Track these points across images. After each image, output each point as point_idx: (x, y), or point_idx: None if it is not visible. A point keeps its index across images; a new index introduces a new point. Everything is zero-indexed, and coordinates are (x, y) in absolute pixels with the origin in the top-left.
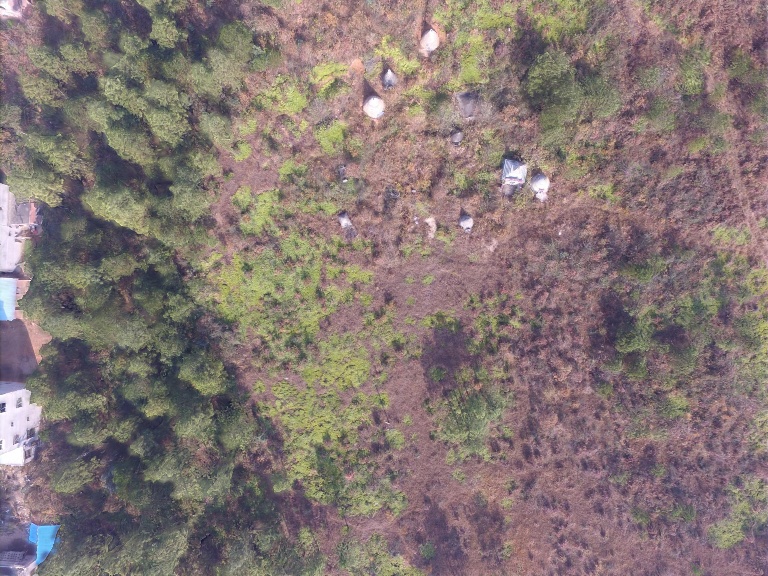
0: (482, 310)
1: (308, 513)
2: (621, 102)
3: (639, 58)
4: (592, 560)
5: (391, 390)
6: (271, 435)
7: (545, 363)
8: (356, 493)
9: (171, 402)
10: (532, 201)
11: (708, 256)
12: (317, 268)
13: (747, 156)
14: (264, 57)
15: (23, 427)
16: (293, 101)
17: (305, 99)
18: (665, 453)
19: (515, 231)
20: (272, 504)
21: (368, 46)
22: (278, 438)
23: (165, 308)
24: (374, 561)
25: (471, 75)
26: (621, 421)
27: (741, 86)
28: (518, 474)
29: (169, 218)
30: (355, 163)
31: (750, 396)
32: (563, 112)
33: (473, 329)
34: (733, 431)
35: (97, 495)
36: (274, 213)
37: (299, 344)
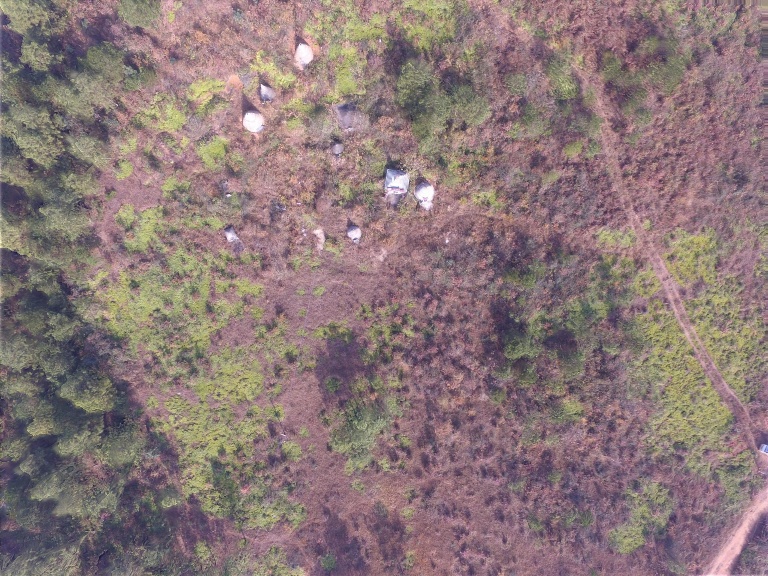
0: (375, 320)
1: (204, 527)
2: (494, 109)
3: (508, 65)
4: (495, 568)
5: (286, 402)
6: (165, 450)
7: (438, 371)
8: (253, 506)
9: (54, 421)
10: (415, 210)
11: (593, 260)
12: (206, 283)
13: (627, 159)
14: (136, 76)
15: None
16: (172, 118)
17: (184, 116)
18: (563, 458)
19: (403, 240)
20: (163, 519)
21: (242, 62)
22: (172, 453)
23: (48, 327)
24: (273, 574)
25: (348, 87)
26: (518, 427)
27: (617, 89)
28: (418, 483)
29: (46, 238)
30: (235, 178)
31: (644, 399)
32: (431, 121)
33: (366, 339)
34: (629, 435)
35: (0, 513)
36: (159, 230)
37: (190, 359)
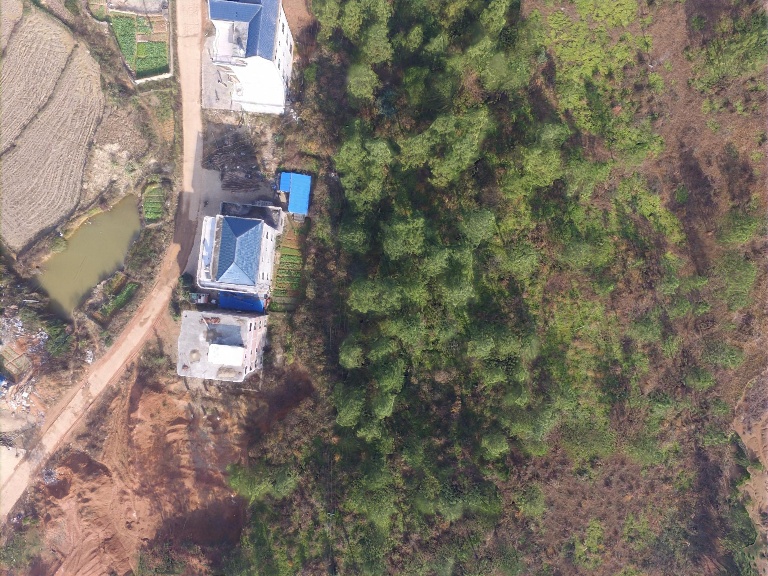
0: None
1: (578, 142)
2: None
3: None
4: None
5: (656, 33)
6: None
7: None
8: (622, 128)
9: None
10: None
11: None
12: None
13: None
14: None
15: (286, 68)
16: None
17: None
18: None
19: None
20: None
21: None
22: (552, 66)
23: None
24: (635, 196)
25: None
26: None
27: None
28: None
29: None
30: None
31: None
32: None
33: None
34: None
35: None
36: None
37: None
